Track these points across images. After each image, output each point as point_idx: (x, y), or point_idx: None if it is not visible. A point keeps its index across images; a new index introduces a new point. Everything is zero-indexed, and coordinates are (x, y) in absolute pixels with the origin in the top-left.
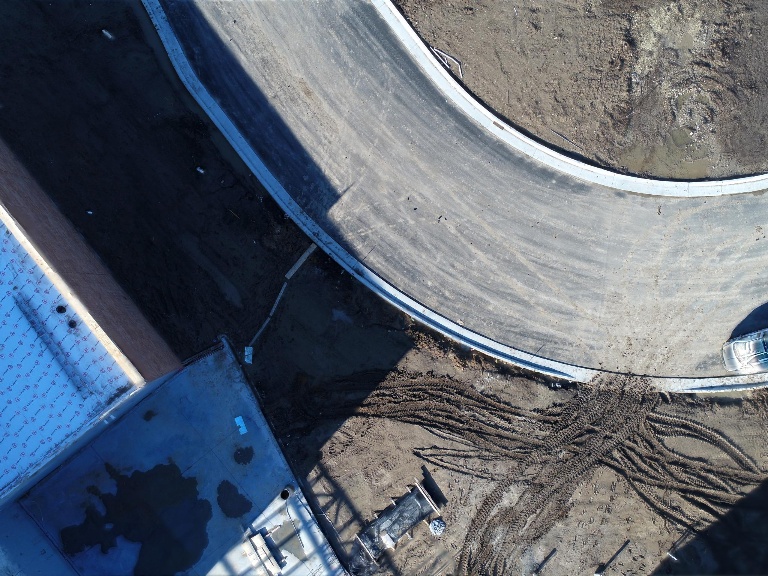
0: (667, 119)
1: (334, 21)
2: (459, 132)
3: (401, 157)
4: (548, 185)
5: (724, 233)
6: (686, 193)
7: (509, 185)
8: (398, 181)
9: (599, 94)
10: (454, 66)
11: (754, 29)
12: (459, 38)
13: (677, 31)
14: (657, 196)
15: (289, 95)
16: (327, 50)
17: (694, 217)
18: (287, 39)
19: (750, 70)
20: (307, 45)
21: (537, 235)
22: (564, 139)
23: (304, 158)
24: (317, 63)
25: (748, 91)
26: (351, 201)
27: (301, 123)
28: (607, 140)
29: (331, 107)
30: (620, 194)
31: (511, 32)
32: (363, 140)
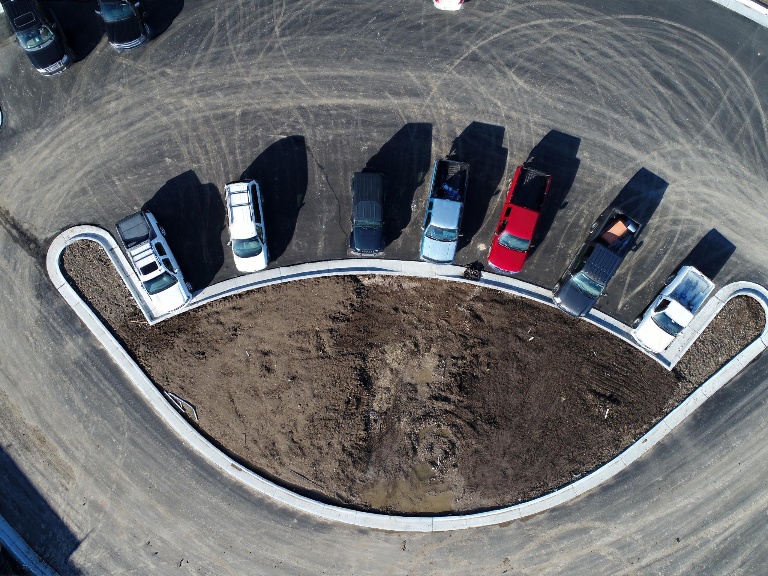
0: (408, 454)
1: (67, 367)
2: (198, 474)
3: (140, 501)
4: (290, 525)
5: (471, 566)
6: (430, 528)
7: (250, 526)
8: (138, 525)
9: (336, 434)
10: (189, 410)
11: (491, 363)
12: (193, 382)
13: (415, 366)
14: (401, 532)
15: (24, 443)
16: (61, 397)
17: (440, 551)
18: (20, 387)
19: (489, 404)
20: (41, 392)
21: (281, 575)
22: (304, 478)
23: (42, 506)
24: (52, 410)
25: (487, 426)
26: (91, 547)
27: (37, 471)
28: (348, 478)
29: (67, 454)
30: (363, 531)
31: (244, 375)
32: (101, 486)
